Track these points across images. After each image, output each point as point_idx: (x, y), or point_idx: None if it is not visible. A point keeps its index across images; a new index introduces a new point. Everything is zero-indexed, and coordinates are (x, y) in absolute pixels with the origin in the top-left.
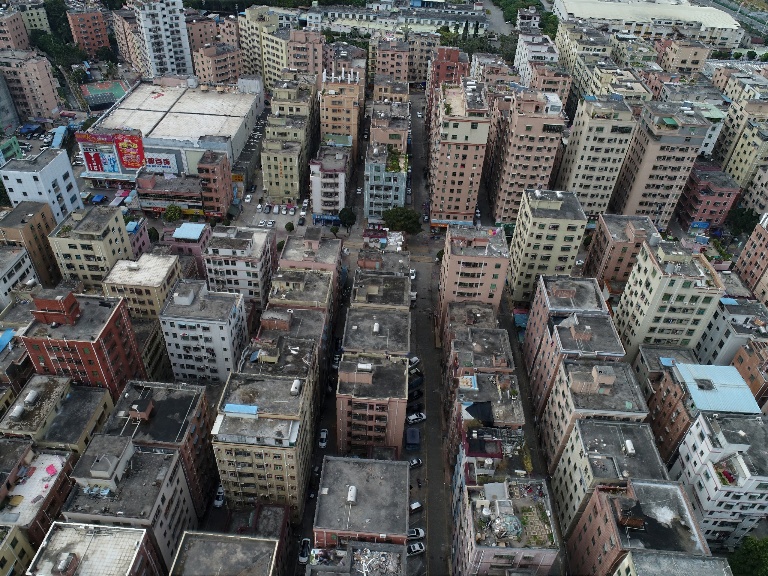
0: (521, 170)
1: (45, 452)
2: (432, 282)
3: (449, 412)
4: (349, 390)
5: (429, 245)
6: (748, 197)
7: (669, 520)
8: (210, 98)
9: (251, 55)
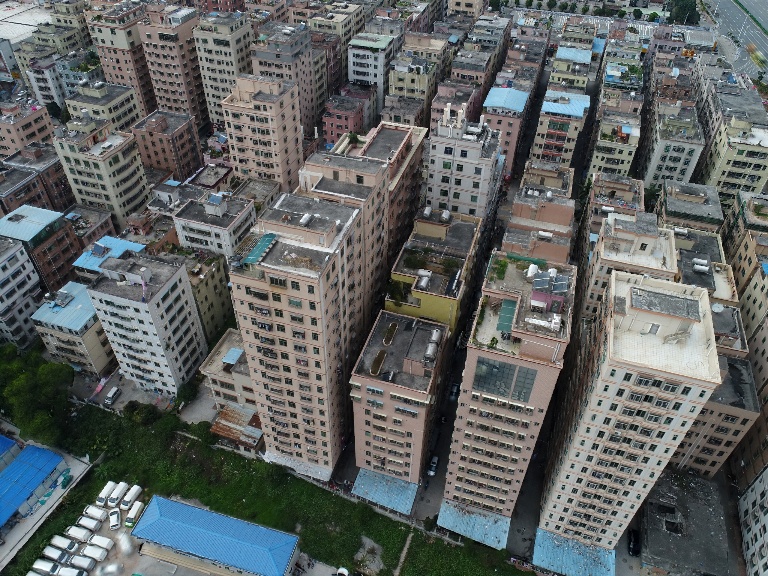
0: (160, 76)
1: None
2: None
3: None
4: None
5: None
6: None
7: None
8: (45, 13)
9: None
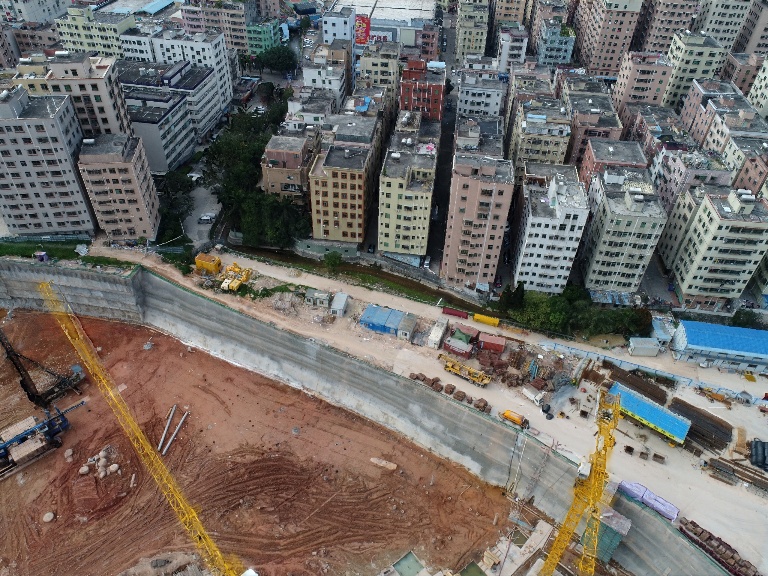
0: (663, 32)
1: (422, 142)
2: None
3: None
4: None
5: None
6: None
7: None
8: None
9: None
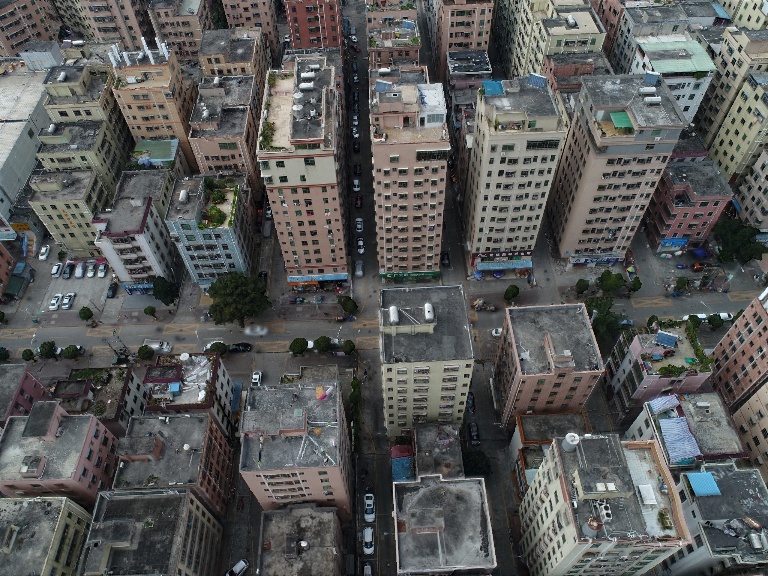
0: (398, 211)
1: None
2: None
3: None
4: None
5: (287, 317)
6: (745, 190)
7: None
8: None
9: None
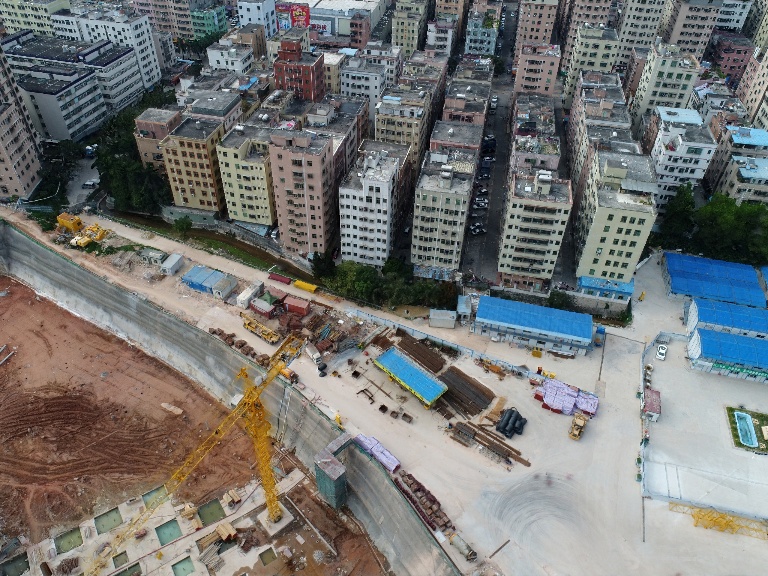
0: None
1: (285, 119)
2: (509, 104)
3: (510, 144)
4: None
5: (509, 85)
6: None
7: None
8: None
9: None
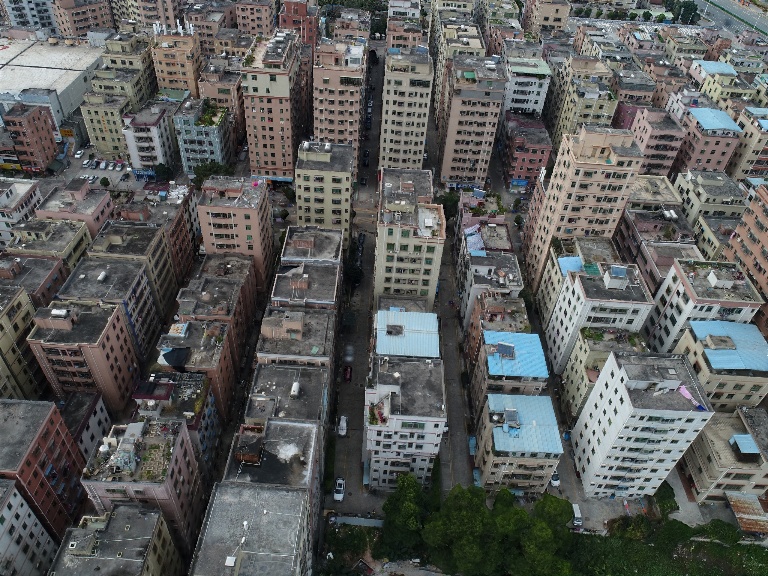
0: (328, 124)
1: None
2: None
3: None
4: (44, 336)
5: None
6: None
7: (289, 456)
8: (56, 51)
9: (120, 8)
